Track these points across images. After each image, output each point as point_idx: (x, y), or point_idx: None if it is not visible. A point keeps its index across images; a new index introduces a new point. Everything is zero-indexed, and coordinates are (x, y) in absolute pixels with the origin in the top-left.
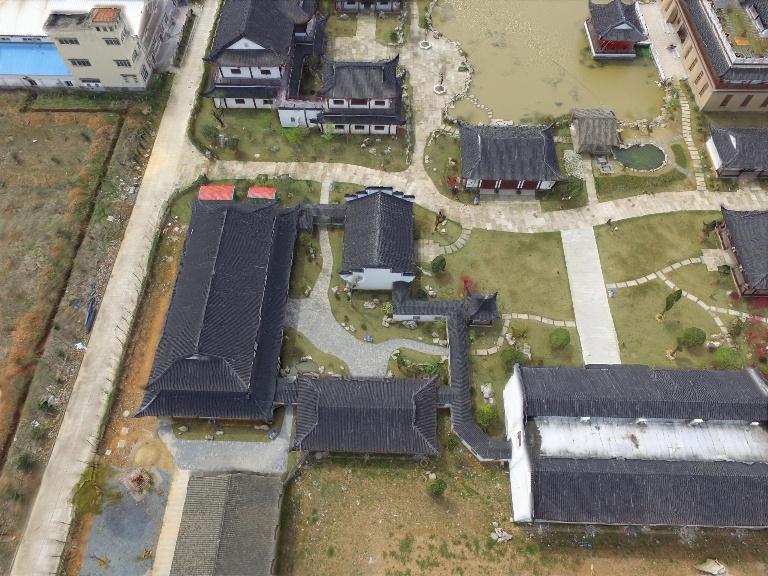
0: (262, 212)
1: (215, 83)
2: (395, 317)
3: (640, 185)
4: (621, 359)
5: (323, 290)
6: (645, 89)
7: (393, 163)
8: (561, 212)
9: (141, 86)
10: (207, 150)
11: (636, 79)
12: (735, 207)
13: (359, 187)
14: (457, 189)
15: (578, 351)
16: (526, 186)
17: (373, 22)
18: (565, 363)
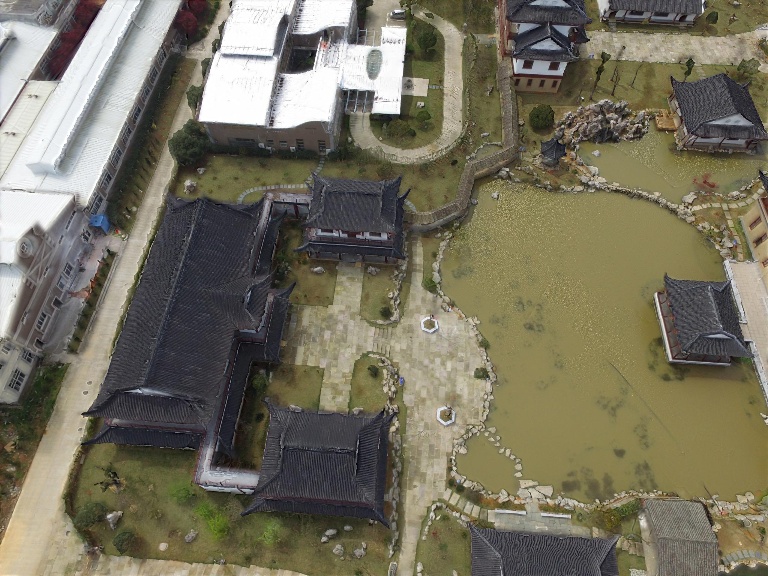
0: None
1: (109, 425)
2: None
3: None
4: None
5: None
6: (746, 426)
7: None
8: None
9: (9, 402)
10: (85, 543)
11: (731, 404)
12: None
13: None
14: None
15: None
16: None
17: (359, 279)
18: None
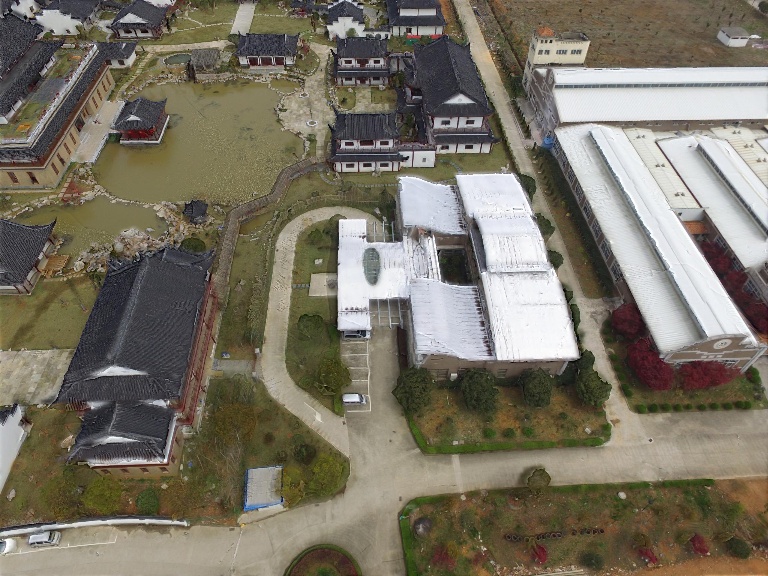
0: (403, 2)
1: None
2: None
3: None
4: (239, 8)
5: (372, 20)
6: None
7: None
8: None
9: None
10: None
11: None
12: None
13: None
14: None
15: (257, 8)
16: None
17: None
18: None
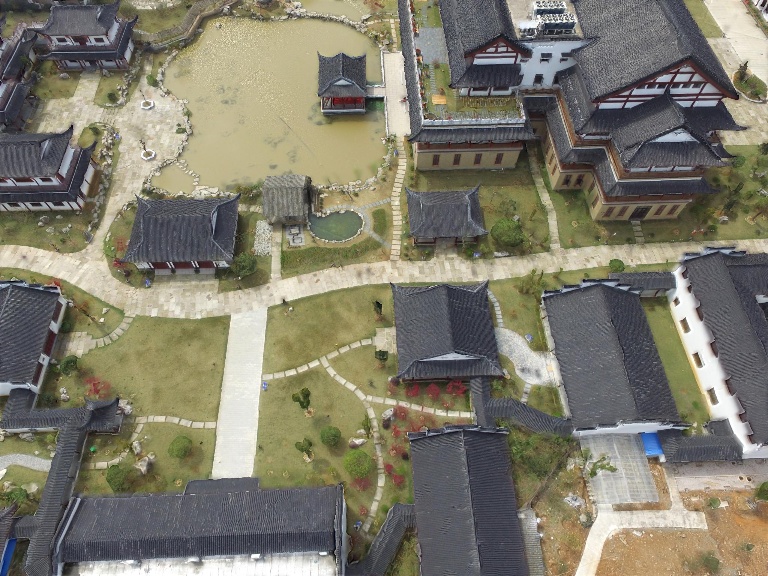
0: None
1: None
2: (9, 430)
3: (329, 257)
4: (254, 464)
5: None
6: (369, 146)
7: (69, 243)
8: (238, 292)
9: None
10: None
11: (364, 135)
12: (424, 278)
13: (24, 272)
14: (131, 270)
15: (208, 458)
16: (203, 265)
17: (96, 81)
18: (190, 473)
